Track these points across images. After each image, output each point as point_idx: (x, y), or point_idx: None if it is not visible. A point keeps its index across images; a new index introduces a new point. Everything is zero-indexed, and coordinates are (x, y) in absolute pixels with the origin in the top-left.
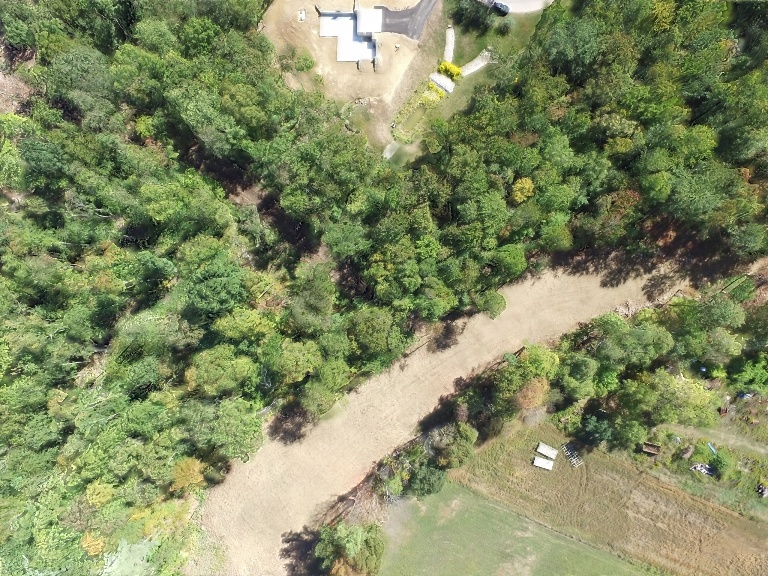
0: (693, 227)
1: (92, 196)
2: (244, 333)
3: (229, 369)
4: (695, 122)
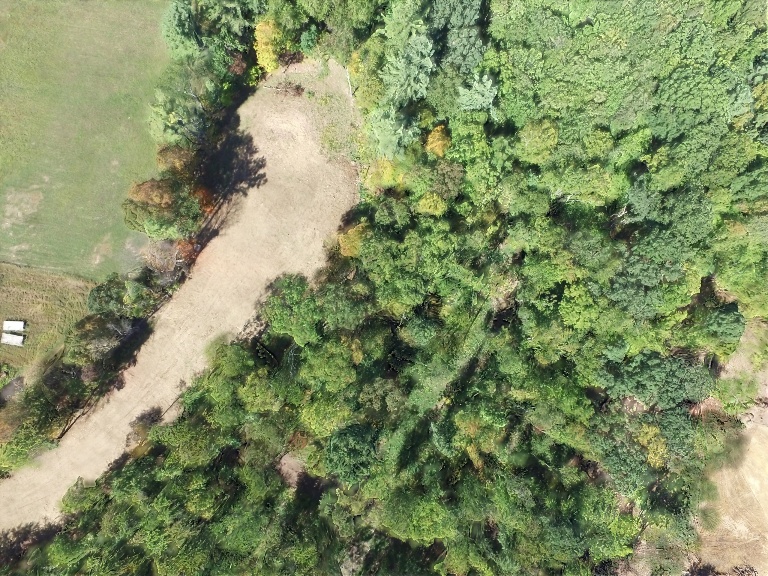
0: None
1: (512, 502)
2: None
3: None
4: None
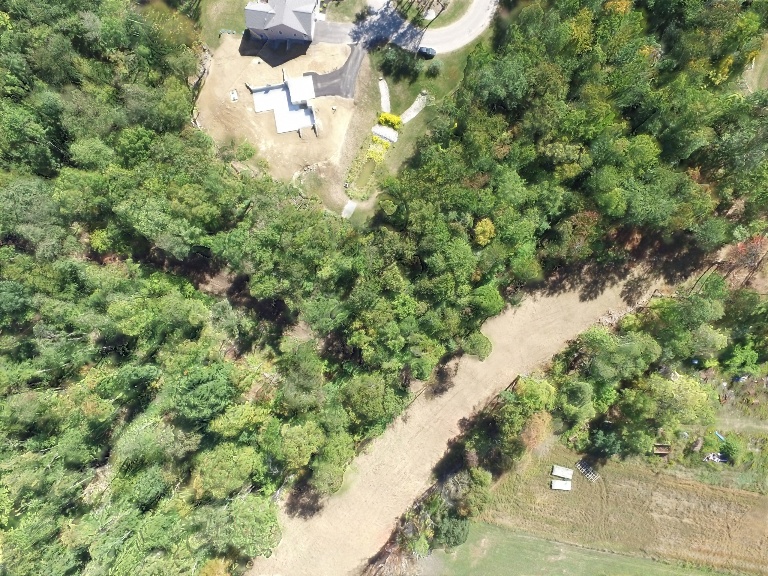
0: (656, 227)
1: (61, 324)
2: (241, 428)
3: (233, 469)
4: (636, 131)
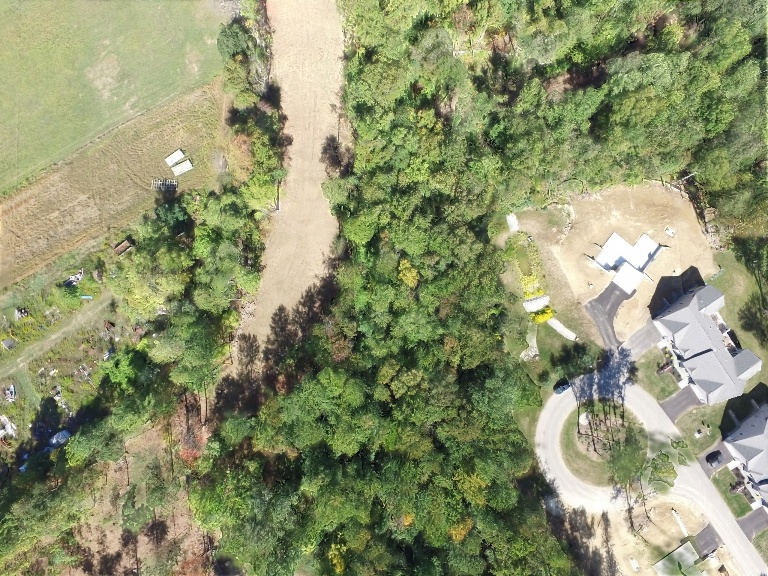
0: None
1: None
2: None
3: None
4: (360, 458)
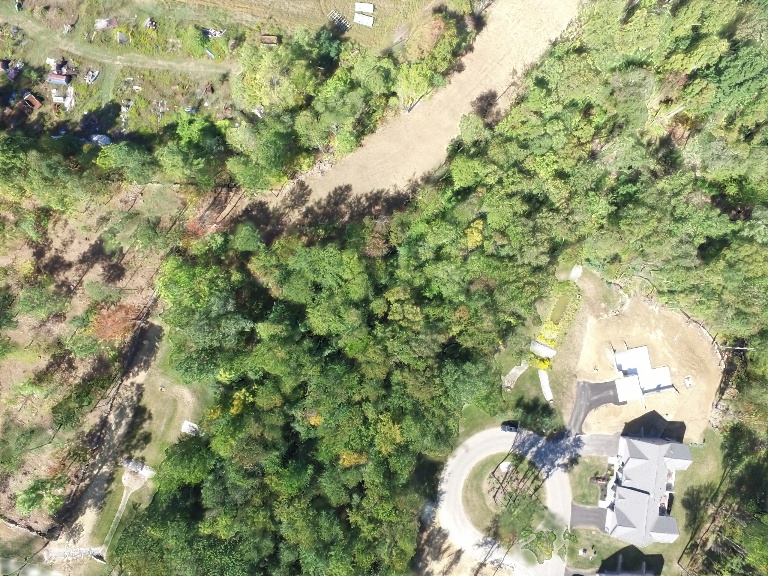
0: None
1: None
2: None
3: (709, 4)
4: None
